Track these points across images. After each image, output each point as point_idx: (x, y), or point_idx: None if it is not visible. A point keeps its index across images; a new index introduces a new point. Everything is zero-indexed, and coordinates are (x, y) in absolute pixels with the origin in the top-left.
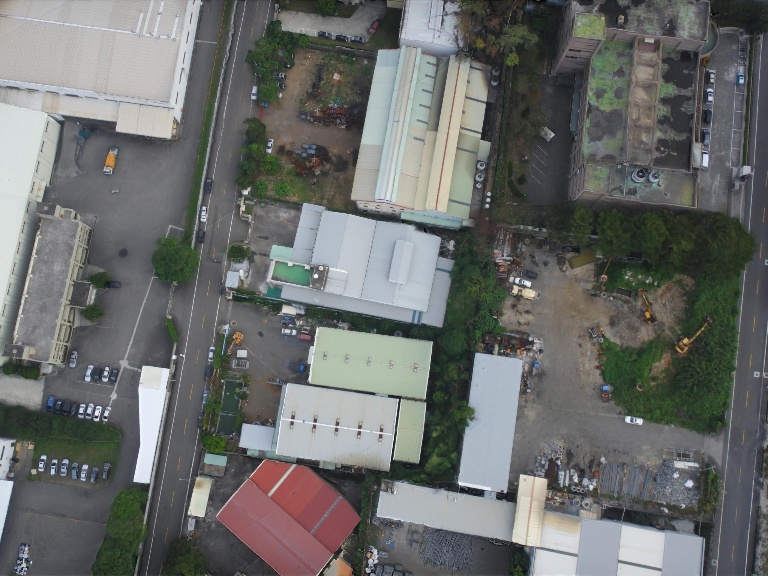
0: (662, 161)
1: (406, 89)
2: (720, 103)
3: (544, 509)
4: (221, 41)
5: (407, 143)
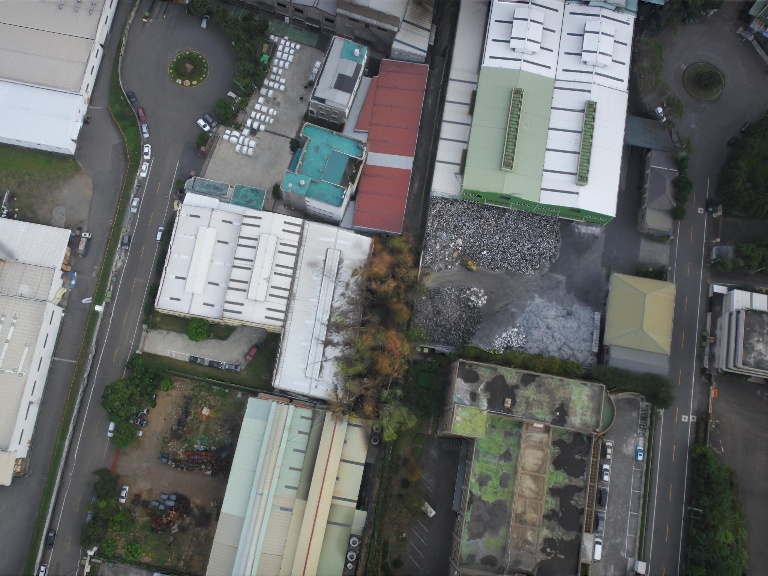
0: (547, 569)
1: (273, 455)
2: (617, 481)
3: None
4: (80, 362)
5: (271, 518)
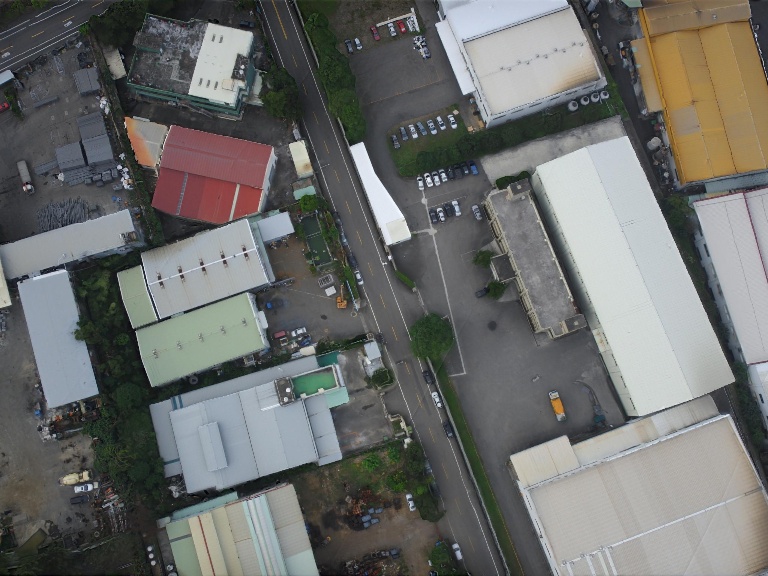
0: None
1: None
2: None
3: None
4: None
5: (261, 574)
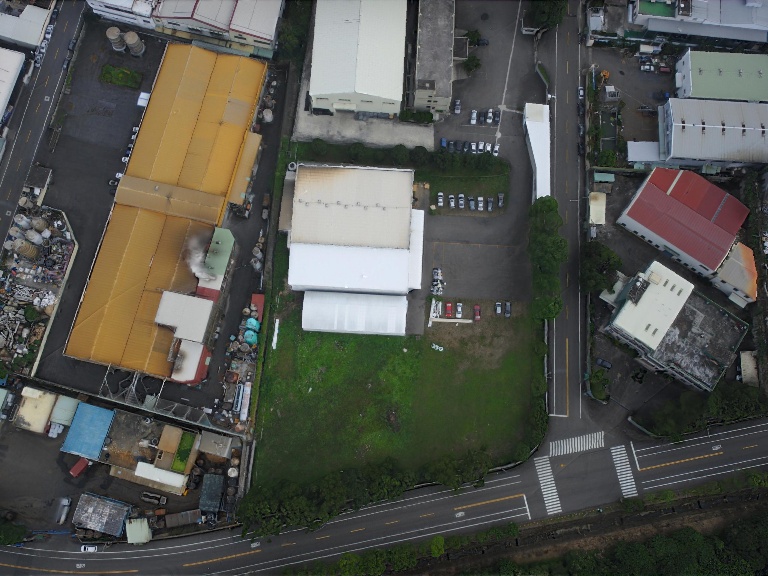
0: None
1: None
2: None
3: None
4: None
5: None
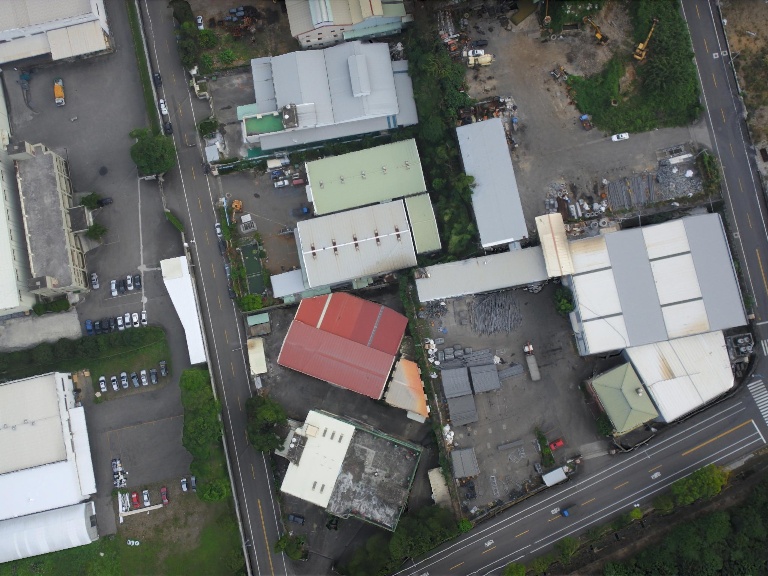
0: None
1: None
2: None
3: (567, 239)
4: None
5: None
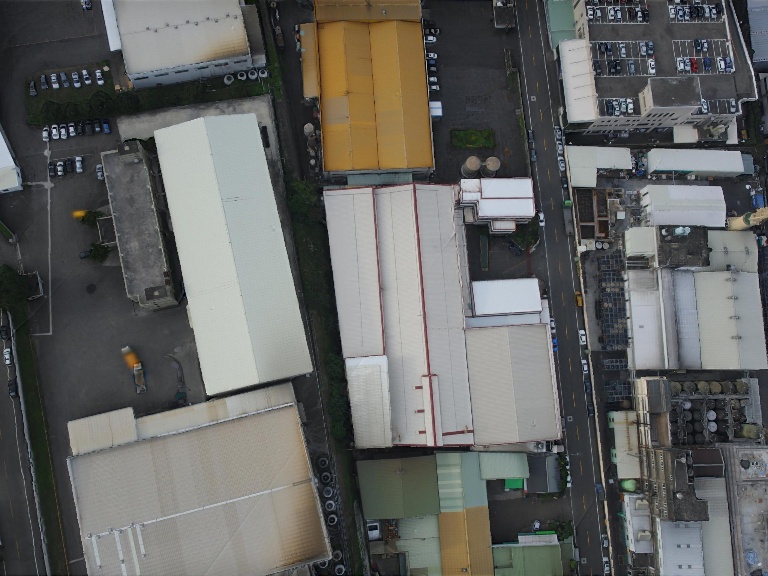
0: None
1: None
2: None
3: None
4: (62, 565)
5: None
